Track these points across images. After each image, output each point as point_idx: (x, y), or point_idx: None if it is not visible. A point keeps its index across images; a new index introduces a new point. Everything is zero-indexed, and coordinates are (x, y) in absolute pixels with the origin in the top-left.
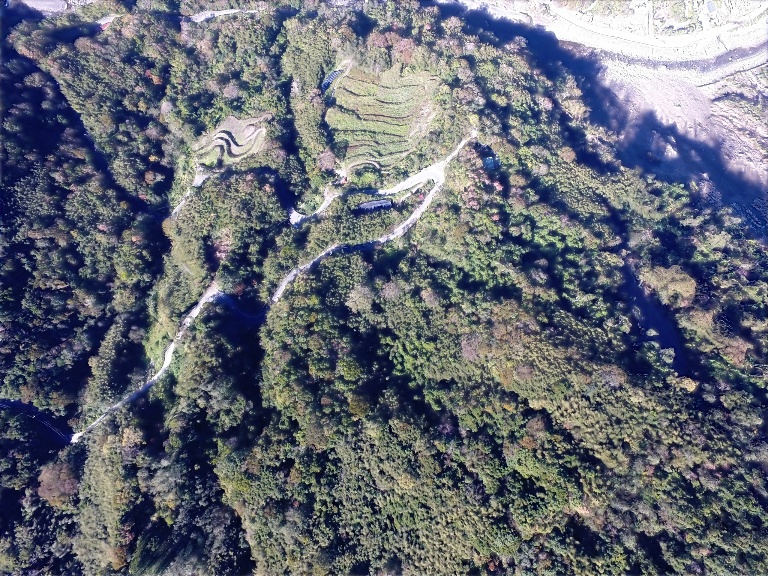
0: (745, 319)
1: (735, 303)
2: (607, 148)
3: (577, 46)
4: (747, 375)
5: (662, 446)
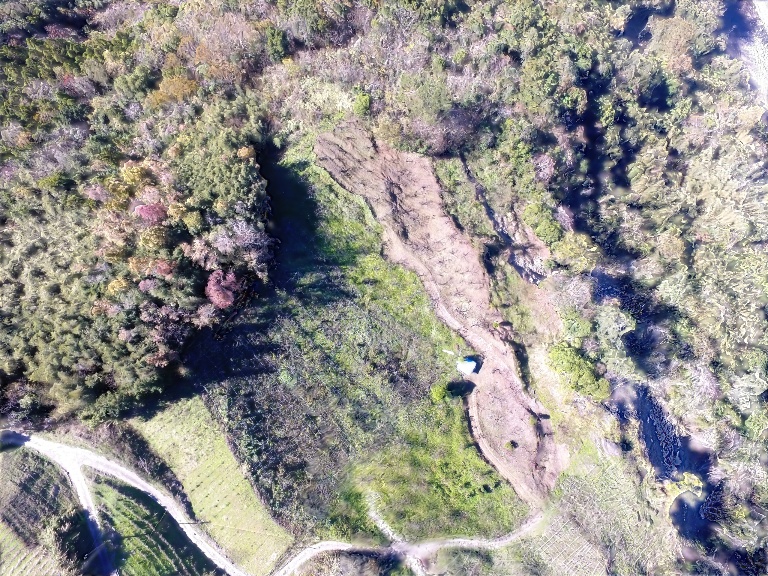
0: (702, 92)
1: (705, 84)
2: (710, 5)
3: (750, 2)
4: (668, 77)
5: (553, 1)
